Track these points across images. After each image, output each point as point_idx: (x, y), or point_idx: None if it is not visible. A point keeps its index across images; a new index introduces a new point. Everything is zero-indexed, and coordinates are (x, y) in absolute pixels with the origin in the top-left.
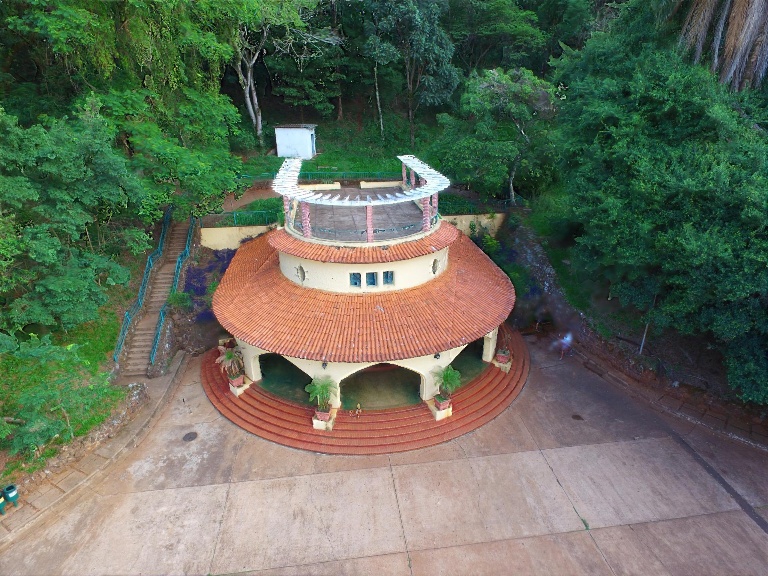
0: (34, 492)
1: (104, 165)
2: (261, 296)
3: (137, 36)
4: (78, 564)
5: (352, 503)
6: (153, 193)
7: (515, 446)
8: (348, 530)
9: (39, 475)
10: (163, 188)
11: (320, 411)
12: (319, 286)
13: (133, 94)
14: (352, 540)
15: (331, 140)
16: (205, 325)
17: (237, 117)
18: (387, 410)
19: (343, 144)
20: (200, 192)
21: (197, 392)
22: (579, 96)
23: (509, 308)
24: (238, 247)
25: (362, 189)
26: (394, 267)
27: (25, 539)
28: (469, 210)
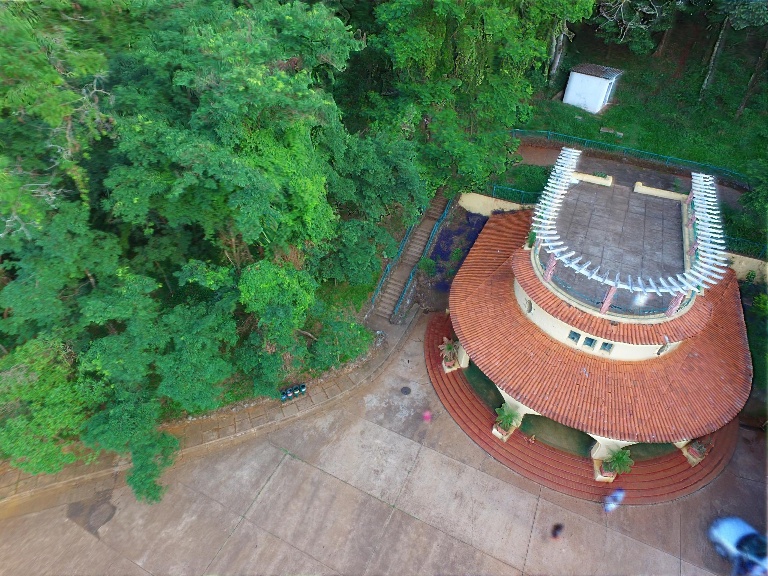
0: (313, 389)
1: (404, 179)
2: (489, 307)
3: (462, 45)
4: (328, 453)
5: (498, 510)
6: (433, 180)
7: (658, 542)
8: (488, 529)
9: (317, 380)
10: (442, 174)
11: (501, 427)
12: (540, 325)
13: (443, 86)
14: (488, 539)
15: (632, 85)
16: (440, 293)
17: (528, 109)
18: (556, 450)
19: (645, 95)
20: (471, 179)
21: (419, 351)
22: None
23: (726, 419)
24: (488, 215)
25: (634, 193)
26: (616, 342)
27: (305, 420)
28: (758, 252)
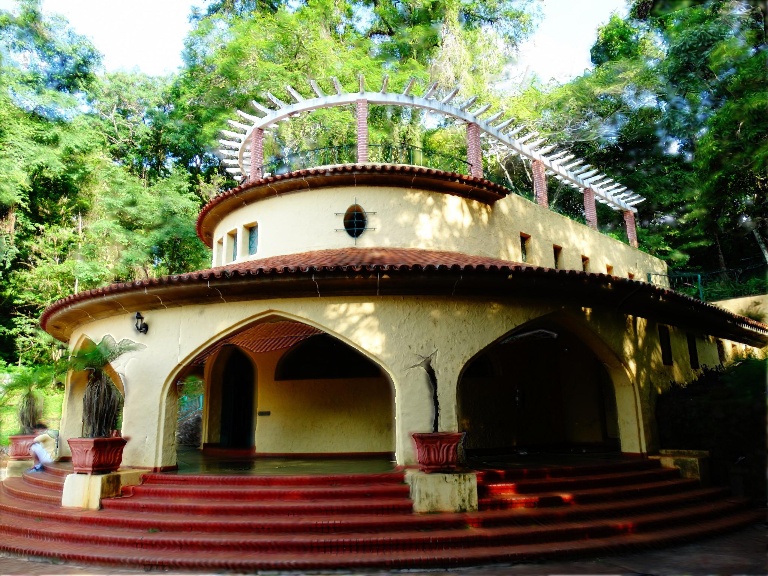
0: None
1: None
2: None
3: (281, 130)
4: None
5: None
6: None
7: None
8: None
9: None
10: None
11: None
12: None
13: None
14: None
15: None
16: None
17: None
18: None
19: None
20: None
21: None
22: None
23: None
24: None
25: None
26: (258, 213)
27: None
28: None
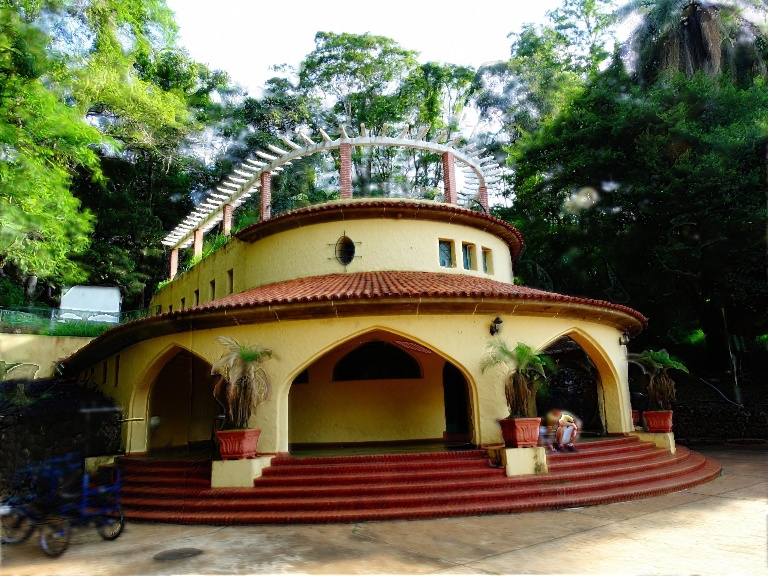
0: None
1: None
2: None
3: None
4: None
5: None
6: None
7: None
8: None
9: None
10: None
11: (521, 417)
12: (384, 265)
13: None
14: None
15: None
16: (47, 426)
17: (117, 144)
18: None
19: None
20: (52, 203)
21: (89, 523)
22: (592, 123)
23: None
24: (47, 375)
25: None
26: (491, 244)
27: None
28: None
